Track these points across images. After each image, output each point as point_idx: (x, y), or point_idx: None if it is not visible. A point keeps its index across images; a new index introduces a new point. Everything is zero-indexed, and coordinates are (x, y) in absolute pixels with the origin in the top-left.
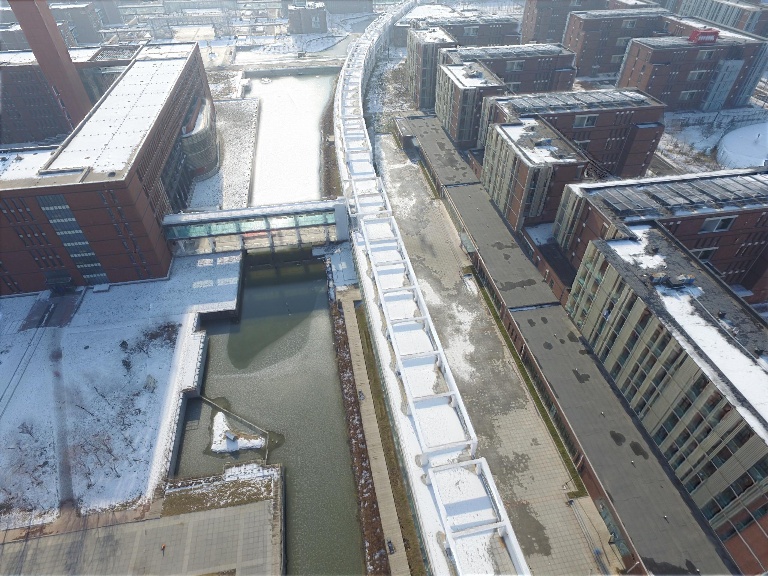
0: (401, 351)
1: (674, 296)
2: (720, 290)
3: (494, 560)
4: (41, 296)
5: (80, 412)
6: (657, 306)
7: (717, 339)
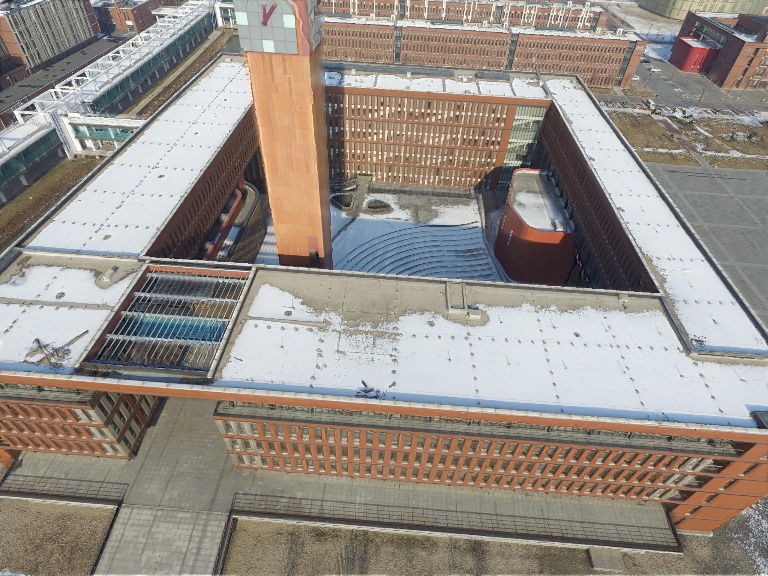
0: (133, 61)
1: (21, 6)
2: None
3: None
4: None
5: None
6: None
7: None
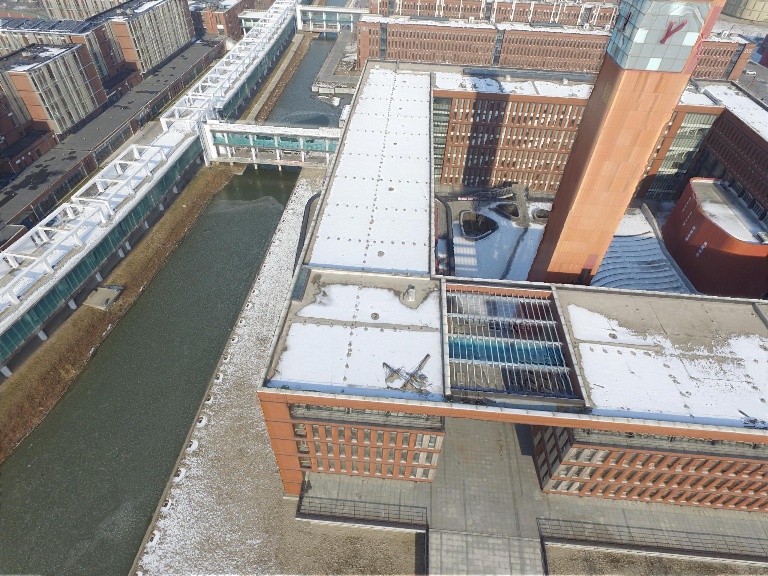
0: None
1: None
2: (113, 11)
3: None
4: None
5: None
6: (148, 9)
7: (145, 6)
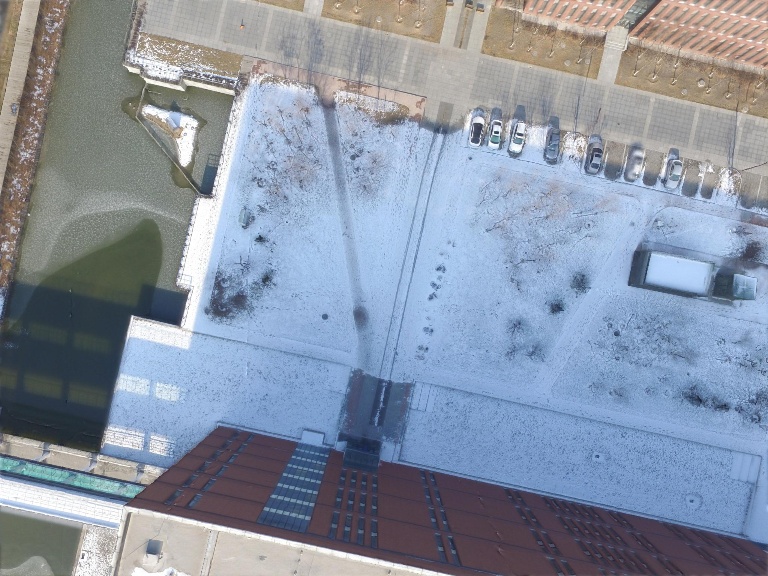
0: None
1: None
2: None
3: None
4: (394, 449)
5: (324, 212)
6: None
7: None
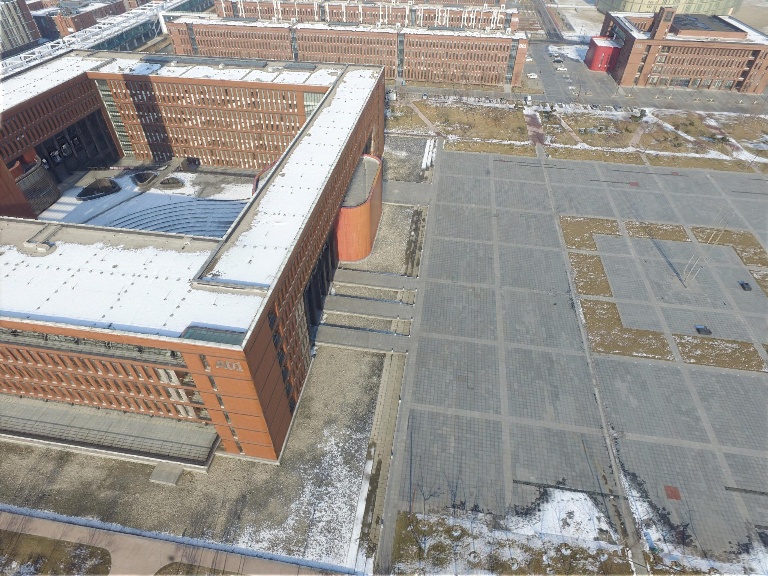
0: None
1: None
2: None
3: (87, 40)
4: None
5: None
6: None
7: None
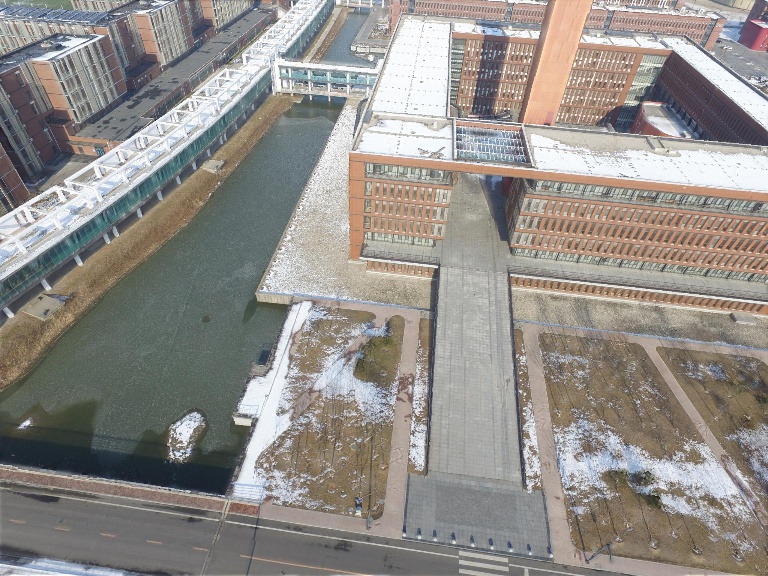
0: None
1: None
2: None
3: None
4: None
5: None
6: None
7: None
